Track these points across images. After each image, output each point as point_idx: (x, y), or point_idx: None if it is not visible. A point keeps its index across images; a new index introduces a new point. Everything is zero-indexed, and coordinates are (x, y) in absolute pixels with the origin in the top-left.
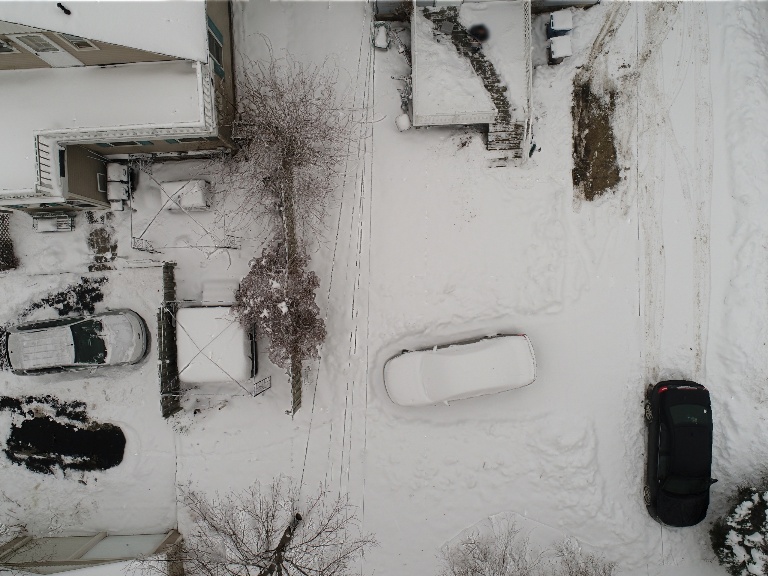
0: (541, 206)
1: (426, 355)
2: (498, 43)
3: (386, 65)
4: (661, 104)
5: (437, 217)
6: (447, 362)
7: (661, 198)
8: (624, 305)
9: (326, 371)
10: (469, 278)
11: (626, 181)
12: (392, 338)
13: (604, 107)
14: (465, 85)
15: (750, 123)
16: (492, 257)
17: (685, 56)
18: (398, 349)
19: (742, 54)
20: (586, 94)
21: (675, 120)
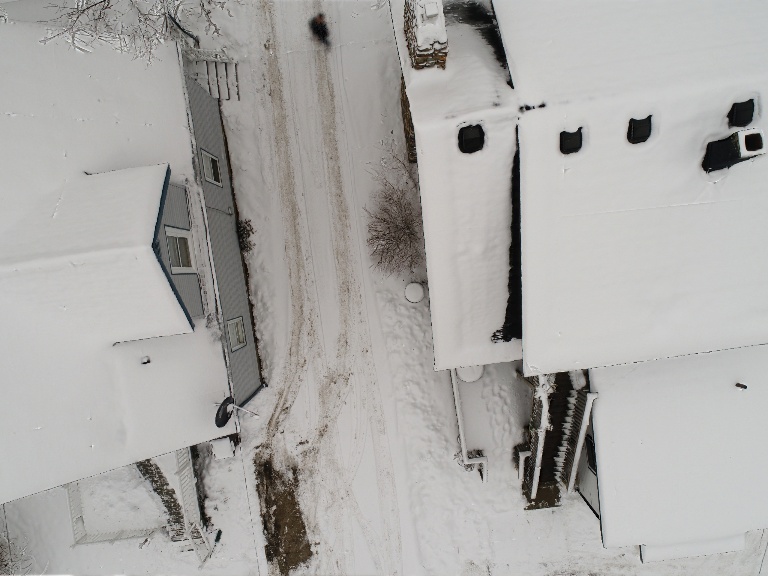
0: None
1: None
2: None
3: None
4: (343, 478)
5: None
6: None
7: (353, 571)
8: None
9: None
10: None
11: (318, 555)
12: None
13: (288, 483)
14: (129, 498)
15: (427, 500)
16: None
17: (362, 428)
18: None
19: (413, 429)
20: (269, 471)
21: (358, 494)
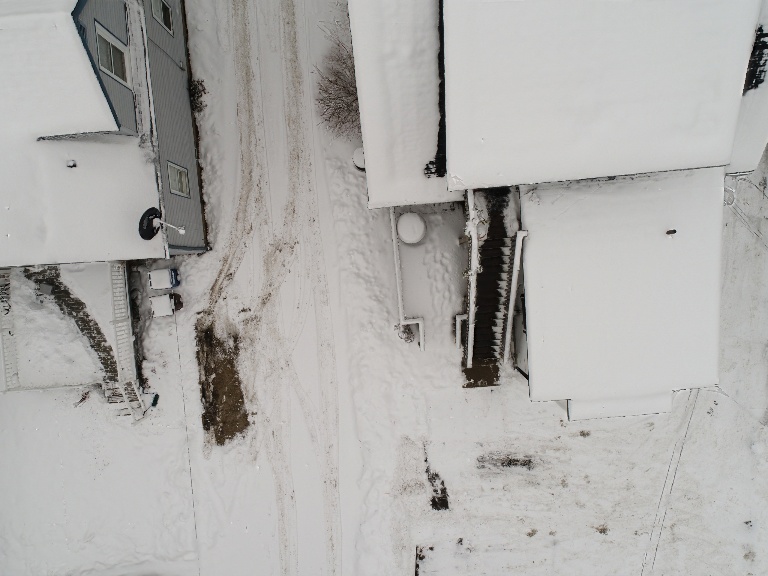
0: (172, 453)
1: None
2: (97, 305)
3: None
4: (284, 348)
5: (72, 465)
6: None
7: (289, 443)
8: (260, 550)
9: None
10: (107, 526)
11: (254, 426)
12: None
13: (228, 351)
14: (64, 350)
15: (365, 371)
16: (130, 503)
17: (305, 298)
18: None
19: (355, 299)
20: (210, 338)
21: (298, 364)
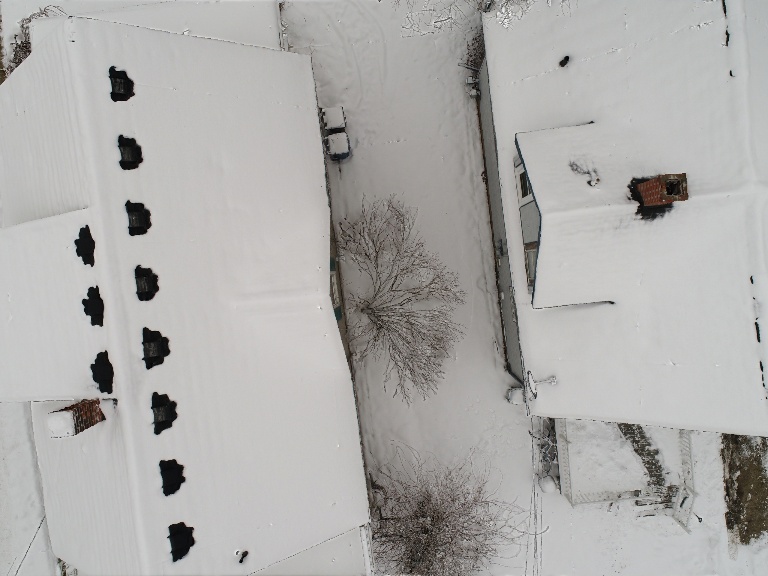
0: (695, 553)
1: None
2: None
3: (521, 417)
4: None
5: (585, 568)
6: None
7: None
8: None
9: None
10: None
11: None
12: None
13: (756, 448)
14: (617, 457)
15: None
16: None
17: None
18: None
19: None
20: None
21: None
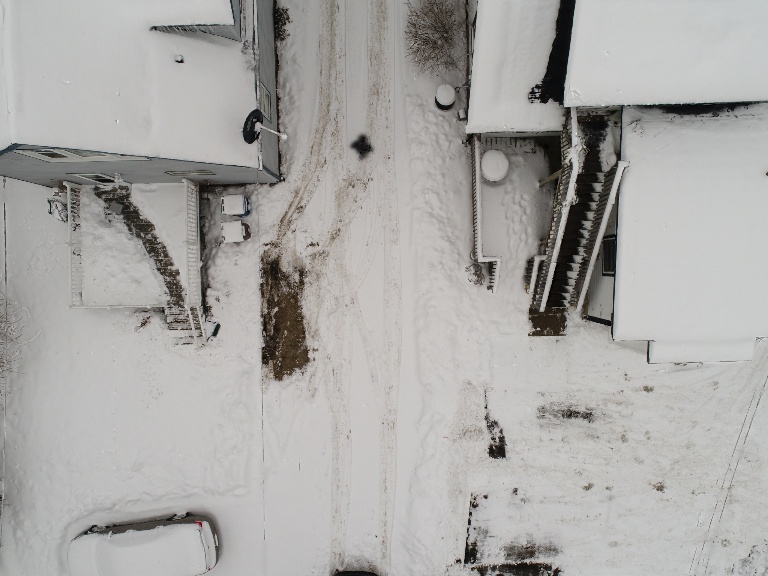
0: (229, 385)
1: (100, 541)
2: (167, 227)
3: None
4: (350, 285)
5: (125, 392)
6: (115, 553)
7: (349, 381)
8: (311, 489)
9: (15, 545)
10: (157, 456)
11: (314, 362)
12: (80, 514)
13: (293, 285)
14: (131, 271)
15: (433, 311)
16: (181, 434)
17: (375, 236)
18: (88, 524)
19: (427, 239)
20: (275, 271)
21: (363, 302)
